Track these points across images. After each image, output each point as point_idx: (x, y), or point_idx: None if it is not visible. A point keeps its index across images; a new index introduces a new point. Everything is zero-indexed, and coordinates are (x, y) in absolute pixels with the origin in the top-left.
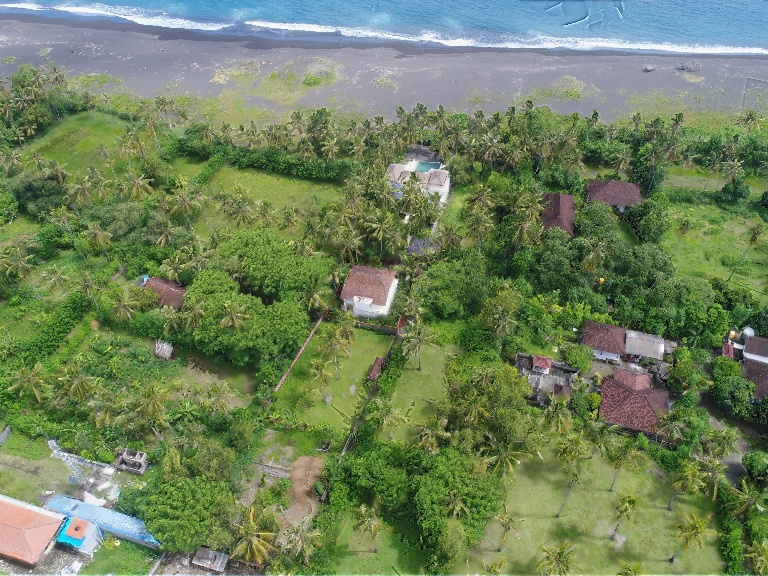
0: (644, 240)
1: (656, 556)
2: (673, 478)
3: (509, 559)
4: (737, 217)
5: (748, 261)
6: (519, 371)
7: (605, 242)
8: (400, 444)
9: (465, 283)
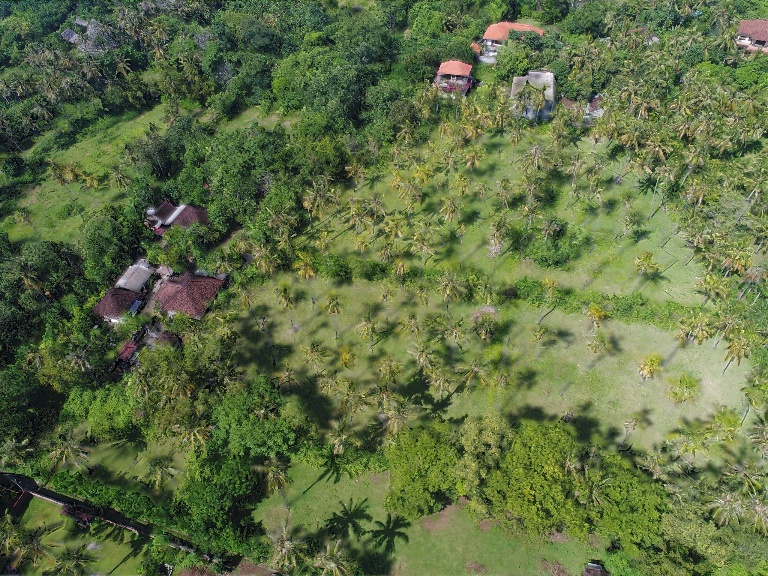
0: (6, 261)
1: (310, 311)
2: (256, 289)
3: (304, 401)
4: (15, 197)
5: (70, 204)
6: (132, 371)
7: (7, 275)
8: (183, 486)
9: (1, 401)
